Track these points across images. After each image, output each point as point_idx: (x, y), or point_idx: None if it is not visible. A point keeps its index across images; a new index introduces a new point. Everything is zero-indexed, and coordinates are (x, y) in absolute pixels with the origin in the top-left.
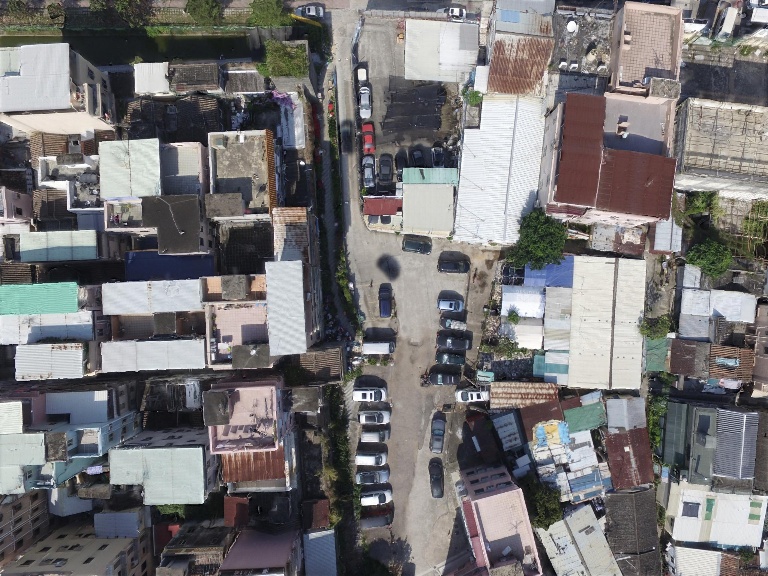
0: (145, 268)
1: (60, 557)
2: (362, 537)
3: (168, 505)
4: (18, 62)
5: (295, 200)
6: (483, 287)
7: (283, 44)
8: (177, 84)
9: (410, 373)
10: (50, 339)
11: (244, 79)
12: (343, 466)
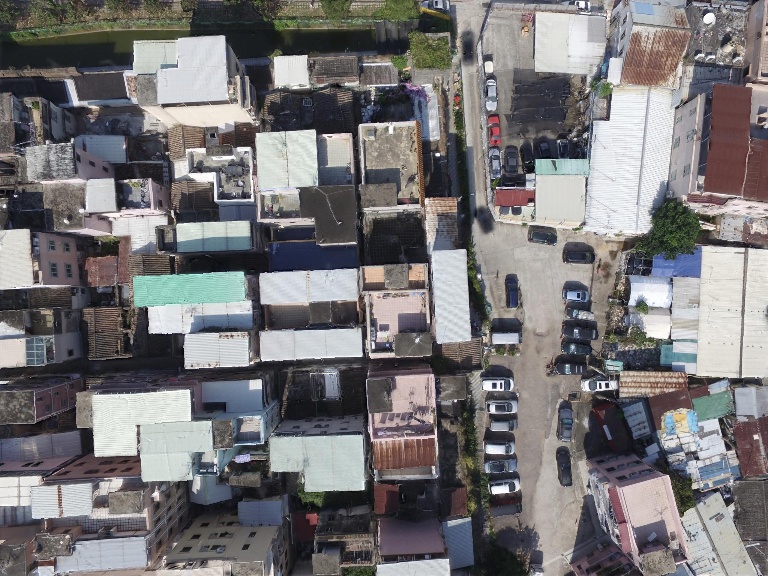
0: (289, 259)
1: (215, 544)
2: (489, 525)
3: (310, 493)
4: (173, 54)
5: (429, 191)
6: (607, 278)
7: (426, 36)
8: (317, 76)
9: (536, 363)
10: (213, 328)
11: (378, 72)
12: (473, 455)
